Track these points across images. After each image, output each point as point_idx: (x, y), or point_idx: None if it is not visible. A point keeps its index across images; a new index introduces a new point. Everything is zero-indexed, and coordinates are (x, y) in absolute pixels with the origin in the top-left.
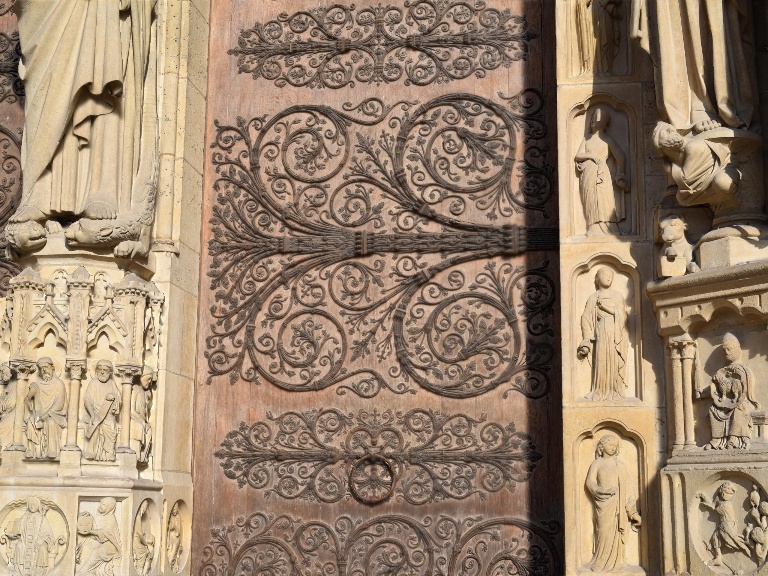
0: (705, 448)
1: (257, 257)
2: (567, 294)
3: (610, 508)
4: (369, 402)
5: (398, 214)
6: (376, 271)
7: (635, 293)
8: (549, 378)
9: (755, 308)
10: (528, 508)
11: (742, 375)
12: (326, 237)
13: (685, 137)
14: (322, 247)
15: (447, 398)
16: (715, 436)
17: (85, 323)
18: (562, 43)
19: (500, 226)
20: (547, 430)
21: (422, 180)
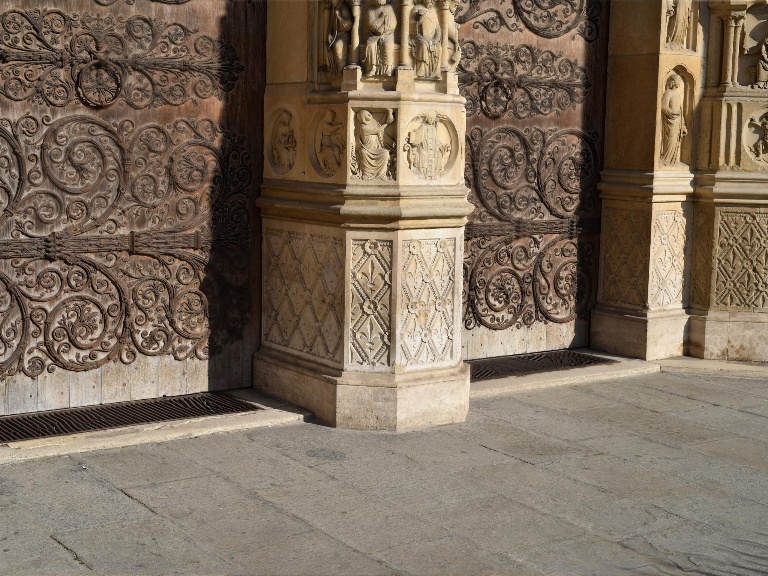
0: (753, 87)
1: None
2: None
3: (678, 124)
4: (494, 36)
5: None
6: None
7: None
8: (599, 27)
9: None
10: (582, 122)
11: None
12: None
13: None
14: None
15: (541, 37)
16: (762, 80)
17: None
18: None
19: None
20: (595, 66)
21: None
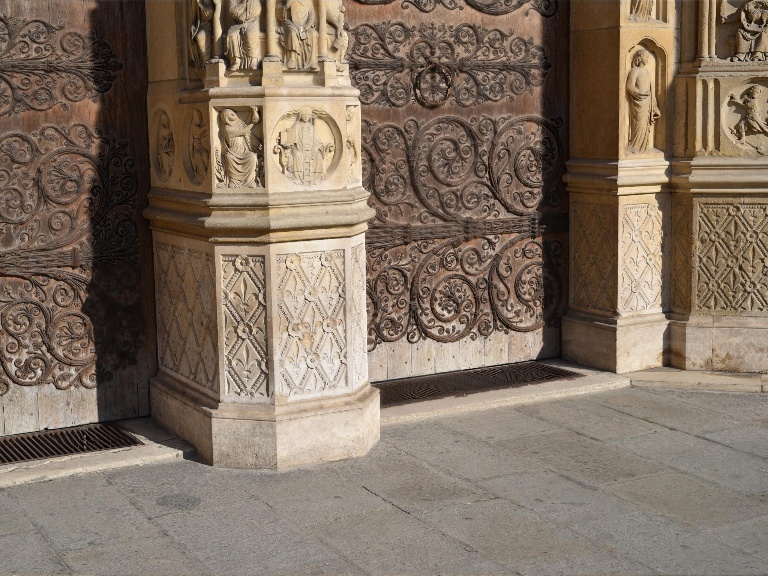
0: (733, 60)
1: None
2: None
3: (647, 106)
4: (428, 16)
5: None
6: None
7: None
8: None
9: None
10: (542, 108)
11: None
12: None
13: None
14: None
15: (486, 14)
16: (742, 52)
17: None
18: None
19: None
20: (555, 44)
21: None
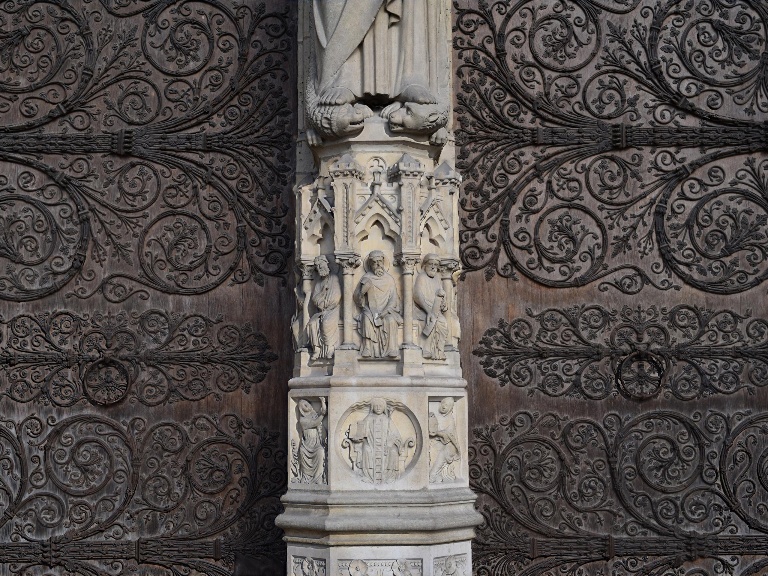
0: None
1: (509, 148)
2: None
3: None
4: (633, 298)
5: (655, 107)
6: (634, 165)
7: None
8: None
9: None
10: None
11: None
12: (582, 129)
13: None
14: (578, 139)
15: (712, 294)
16: None
17: (418, 214)
18: None
19: (761, 122)
20: None
21: (677, 73)
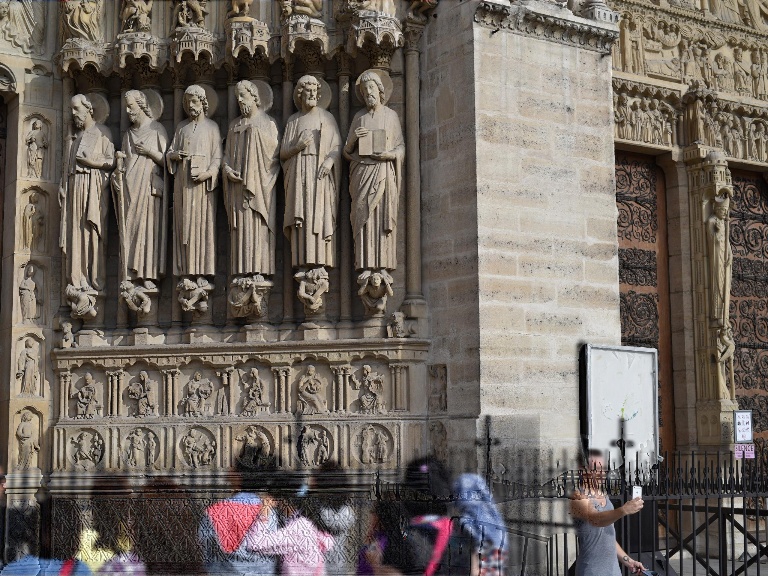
0: (74, 418)
1: None
2: (14, 350)
3: (28, 443)
4: None
5: None
6: None
7: (43, 350)
8: None
9: (102, 364)
10: None
11: (93, 390)
12: None
13: (79, 292)
14: None
15: None
16: (79, 414)
17: None
18: (18, 234)
19: None
20: None
21: None
